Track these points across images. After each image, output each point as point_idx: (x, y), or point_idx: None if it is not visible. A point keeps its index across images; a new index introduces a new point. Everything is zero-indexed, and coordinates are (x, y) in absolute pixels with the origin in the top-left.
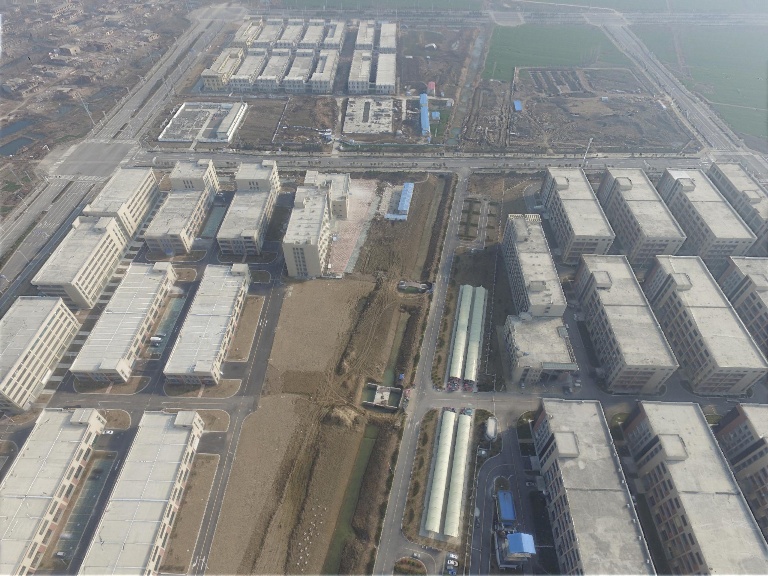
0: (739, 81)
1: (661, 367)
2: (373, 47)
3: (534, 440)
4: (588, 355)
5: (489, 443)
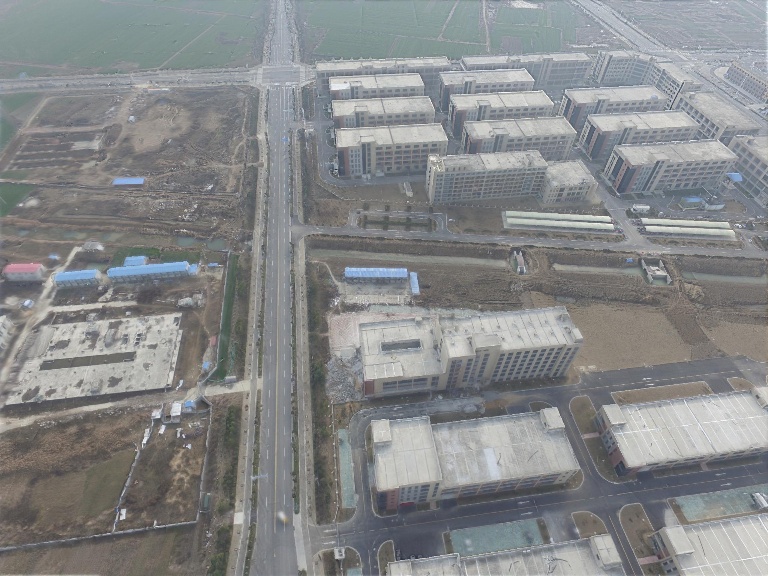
0: (117, 48)
1: None
2: None
3: (632, 193)
4: None
5: None
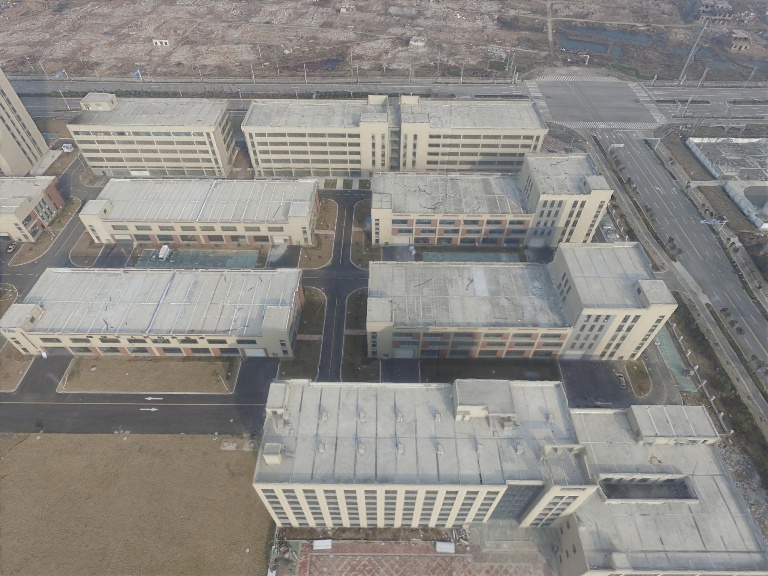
0: None
1: None
2: None
3: None
4: None
5: None
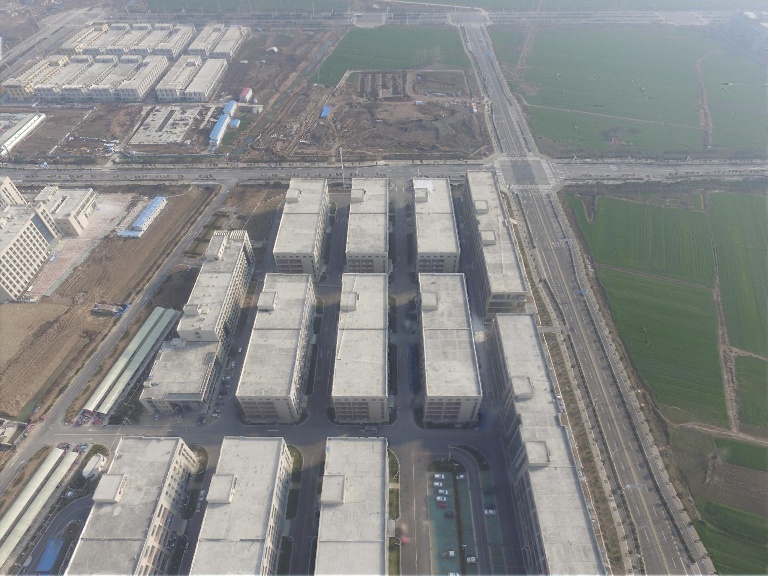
0: (569, 82)
1: (273, 397)
2: None
3: None
4: None
5: (85, 483)
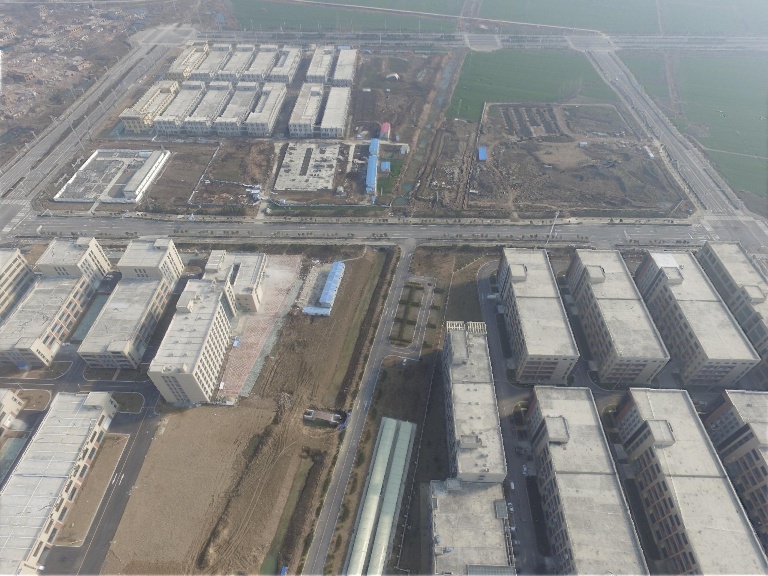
0: (738, 121)
1: None
2: (327, 78)
3: None
4: (537, 535)
5: None
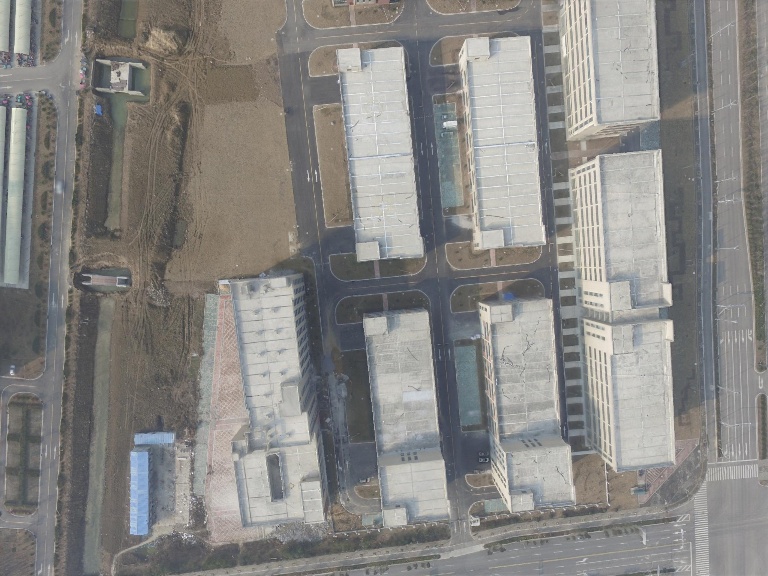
0: None
1: None
2: None
3: None
4: None
5: None
